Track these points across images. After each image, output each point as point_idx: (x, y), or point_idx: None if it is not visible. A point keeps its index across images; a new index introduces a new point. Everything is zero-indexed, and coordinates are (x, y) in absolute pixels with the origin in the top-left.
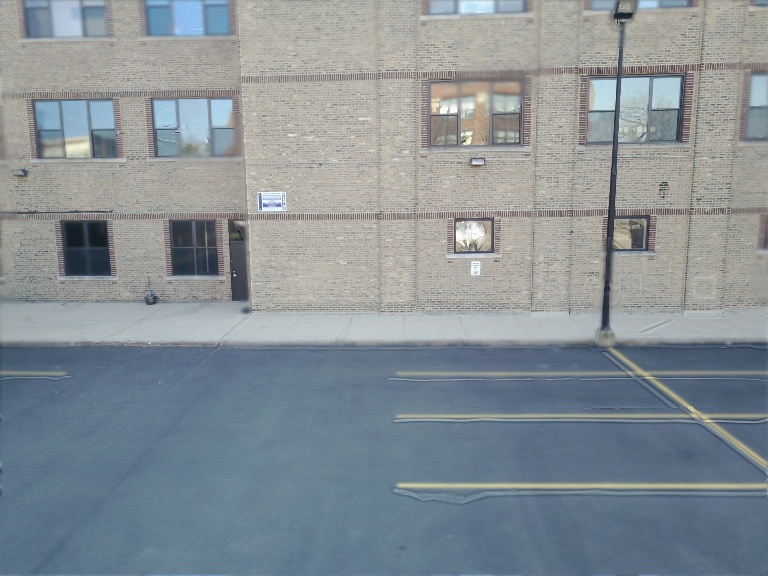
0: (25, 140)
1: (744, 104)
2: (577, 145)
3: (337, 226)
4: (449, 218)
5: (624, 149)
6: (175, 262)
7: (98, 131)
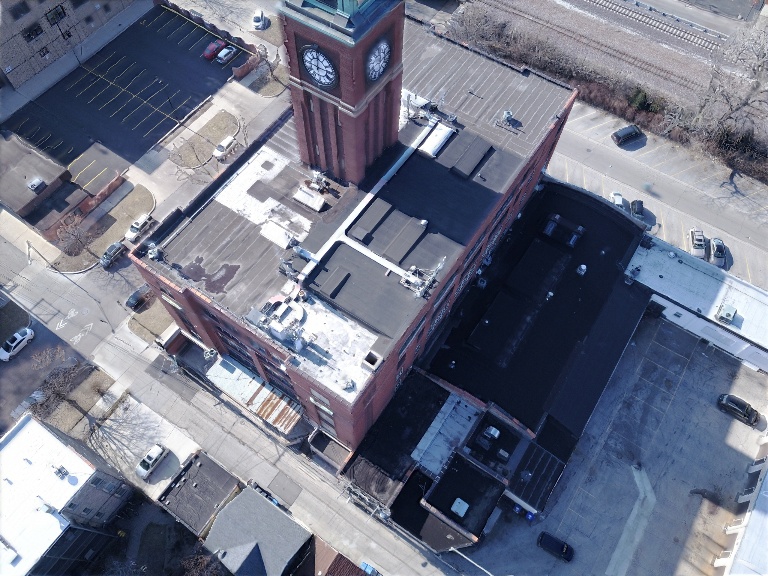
0: None
1: (71, 4)
2: None
3: None
4: (38, 52)
5: None
6: None
7: None
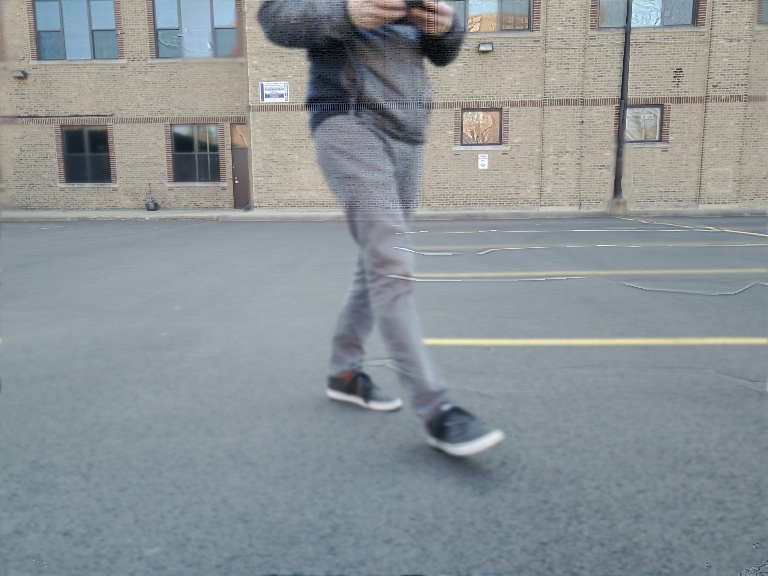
0: (25, 41)
1: None
2: (588, 30)
3: (341, 117)
4: (456, 108)
5: (637, 34)
6: (176, 168)
7: (99, 32)
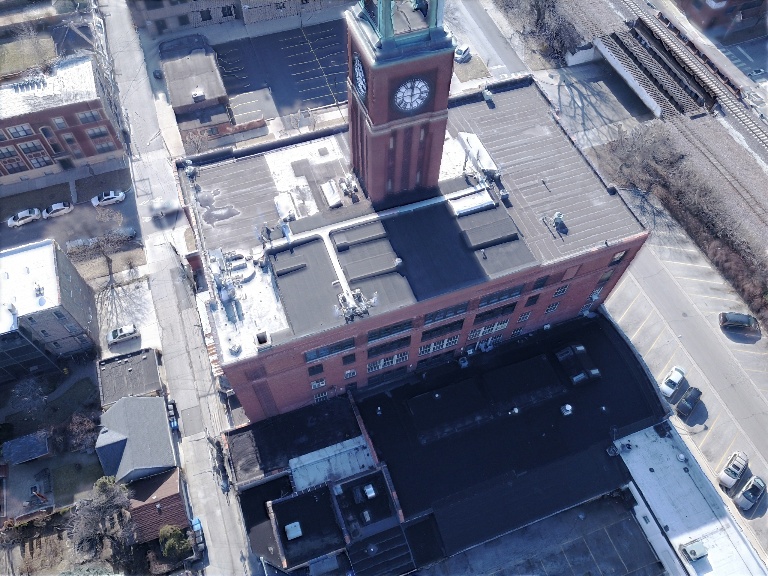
0: None
1: None
2: None
3: None
4: None
5: None
6: None
7: None
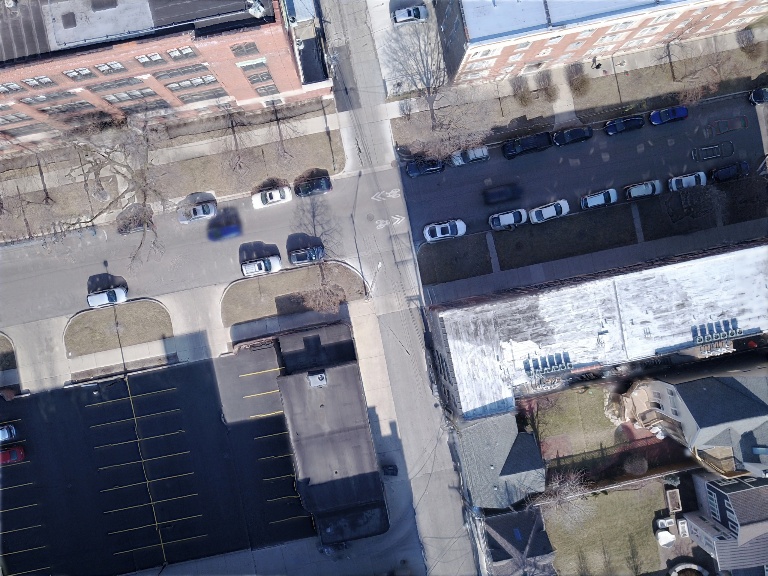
0: None
1: None
2: None
3: None
4: None
5: None
6: None
7: None
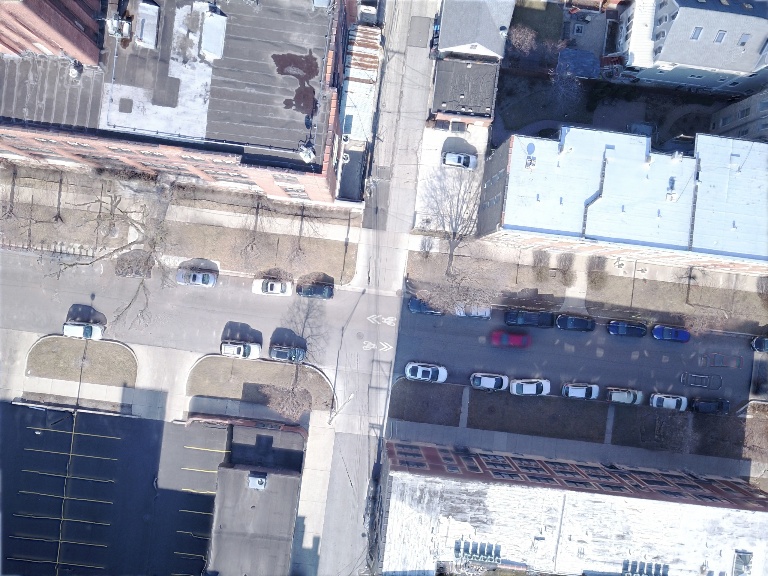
0: None
1: None
2: None
3: None
4: None
5: None
6: None
7: None
